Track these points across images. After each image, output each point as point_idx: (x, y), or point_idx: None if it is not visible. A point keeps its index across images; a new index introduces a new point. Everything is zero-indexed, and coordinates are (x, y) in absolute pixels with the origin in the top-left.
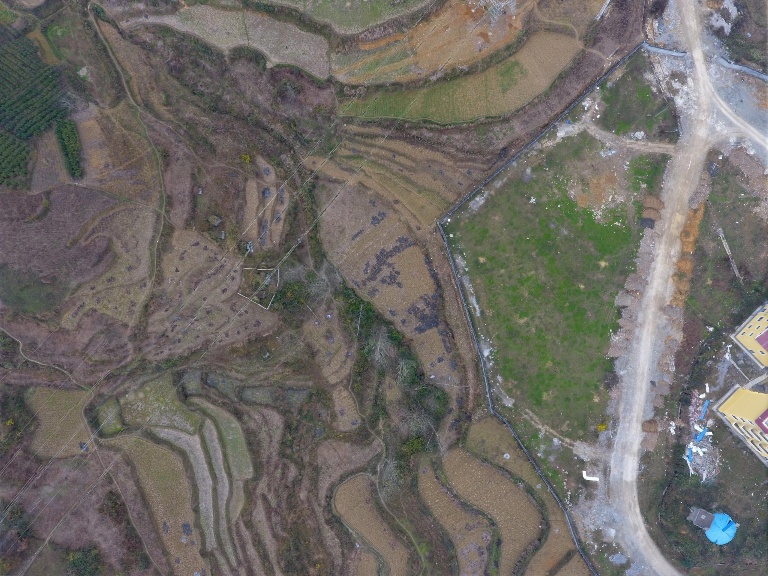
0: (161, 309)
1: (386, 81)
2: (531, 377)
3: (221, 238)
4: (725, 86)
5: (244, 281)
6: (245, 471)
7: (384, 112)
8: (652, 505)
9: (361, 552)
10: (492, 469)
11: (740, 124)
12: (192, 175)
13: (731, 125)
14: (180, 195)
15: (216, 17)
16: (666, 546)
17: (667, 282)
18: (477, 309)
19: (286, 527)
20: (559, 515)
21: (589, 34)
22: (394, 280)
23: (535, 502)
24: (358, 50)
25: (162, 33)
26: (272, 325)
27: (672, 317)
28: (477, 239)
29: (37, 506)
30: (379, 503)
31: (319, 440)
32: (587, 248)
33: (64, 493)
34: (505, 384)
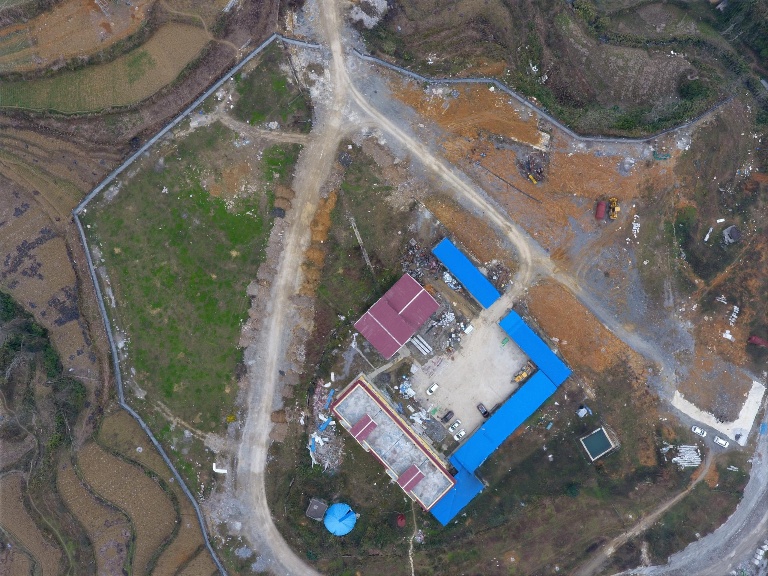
0: None
1: (5, 70)
2: (162, 368)
3: None
4: (361, 77)
5: None
6: None
7: (8, 102)
8: (279, 497)
9: (14, 552)
10: None
11: (373, 114)
12: None
13: (364, 115)
14: None
15: None
16: (293, 538)
17: (296, 271)
18: (112, 300)
19: None
20: (191, 509)
21: (215, 25)
22: (35, 272)
23: None
24: None
25: None
26: None
27: (300, 306)
28: (113, 230)
29: None
30: (27, 501)
31: None
32: (218, 238)
33: None
34: (137, 376)
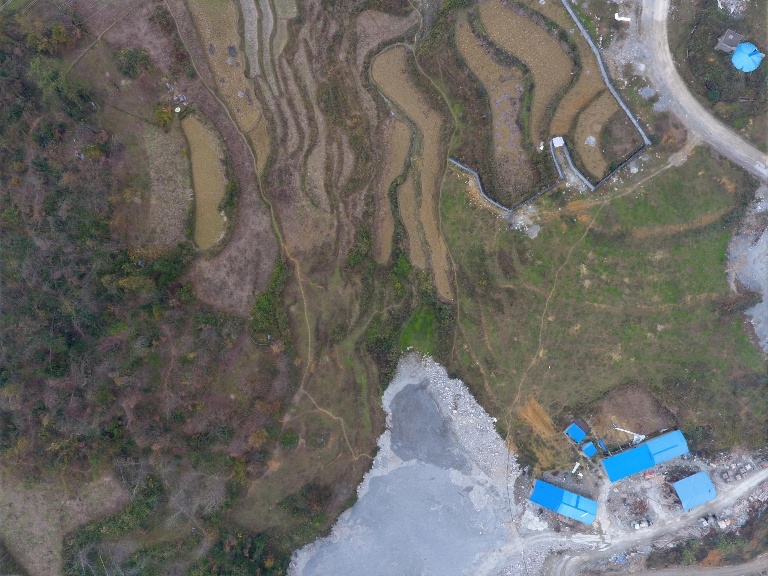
0: None
1: None
2: None
3: None
4: None
5: None
6: (289, 11)
7: None
8: (681, 43)
9: (395, 121)
10: (527, 19)
11: None
12: None
13: None
14: None
15: None
16: (693, 82)
17: None
18: None
19: (326, 75)
20: (591, 58)
21: None
22: None
23: (568, 48)
24: None
25: None
26: None
27: None
28: None
29: (90, 9)
30: (415, 67)
31: (359, 4)
32: None
33: (116, 3)
34: None
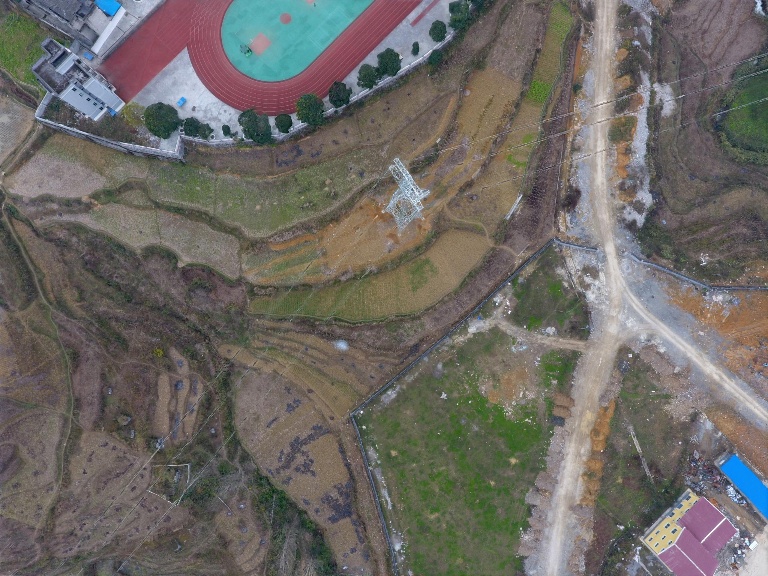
0: (69, 510)
1: None
2: (441, 574)
3: (130, 437)
4: (636, 281)
5: (154, 478)
6: None
7: (295, 310)
8: None
9: None
10: None
11: (651, 320)
12: (102, 375)
13: (642, 321)
14: (89, 397)
15: (129, 215)
16: None
17: (577, 481)
18: (389, 502)
19: None
20: None
21: (498, 234)
22: (308, 468)
23: None
24: (268, 250)
25: (76, 229)
26: (182, 520)
27: (582, 517)
28: (389, 432)
29: None
30: None
31: None
32: (498, 445)
33: None
34: None
